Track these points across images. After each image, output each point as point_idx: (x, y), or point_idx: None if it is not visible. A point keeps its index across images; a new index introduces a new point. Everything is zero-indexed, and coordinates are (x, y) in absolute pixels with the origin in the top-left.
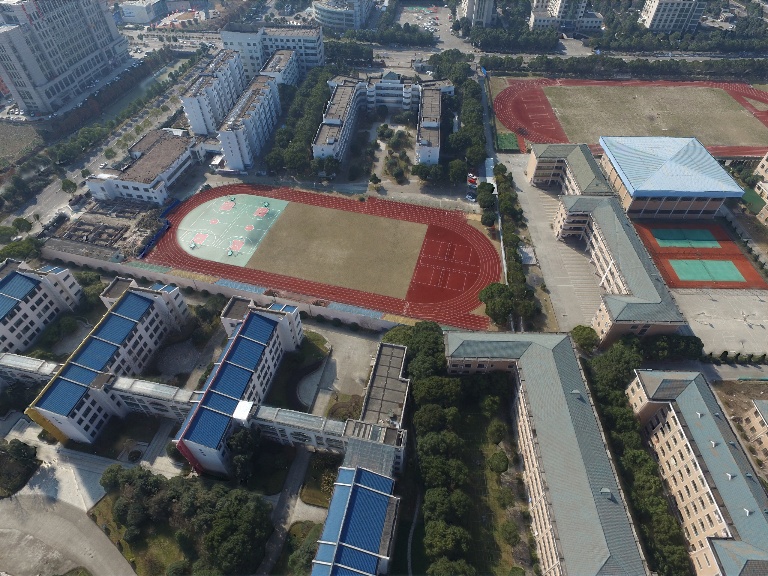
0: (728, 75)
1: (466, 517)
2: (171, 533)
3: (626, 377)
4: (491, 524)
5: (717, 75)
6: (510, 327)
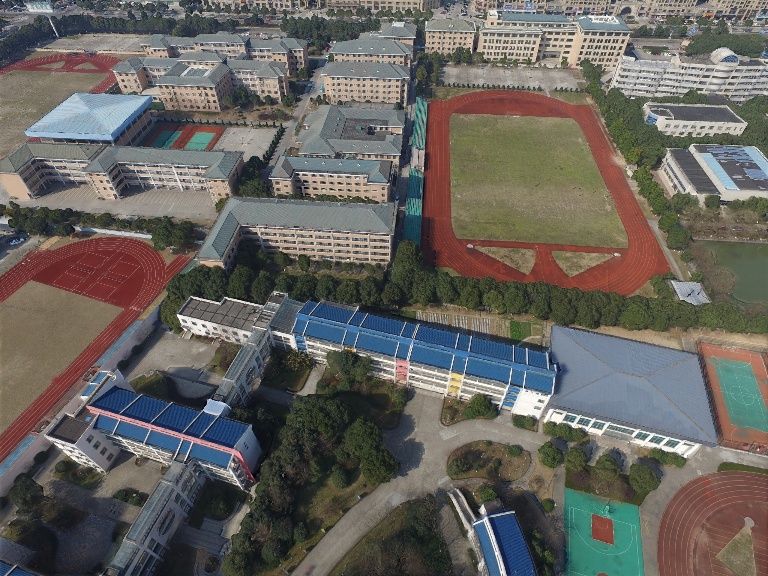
0: None
1: (336, 280)
2: (306, 498)
3: (267, 191)
4: (339, 280)
5: None
6: (195, 244)
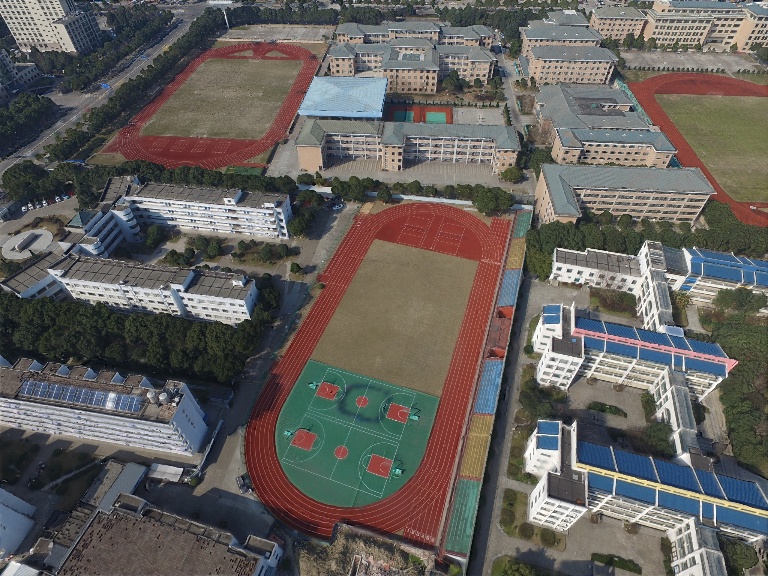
0: (190, 50)
1: None
2: None
3: None
4: None
5: (187, 54)
6: None
